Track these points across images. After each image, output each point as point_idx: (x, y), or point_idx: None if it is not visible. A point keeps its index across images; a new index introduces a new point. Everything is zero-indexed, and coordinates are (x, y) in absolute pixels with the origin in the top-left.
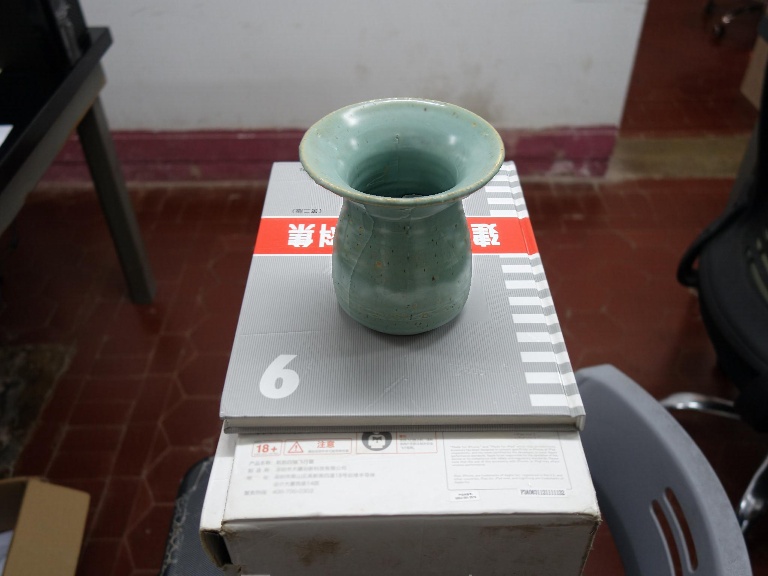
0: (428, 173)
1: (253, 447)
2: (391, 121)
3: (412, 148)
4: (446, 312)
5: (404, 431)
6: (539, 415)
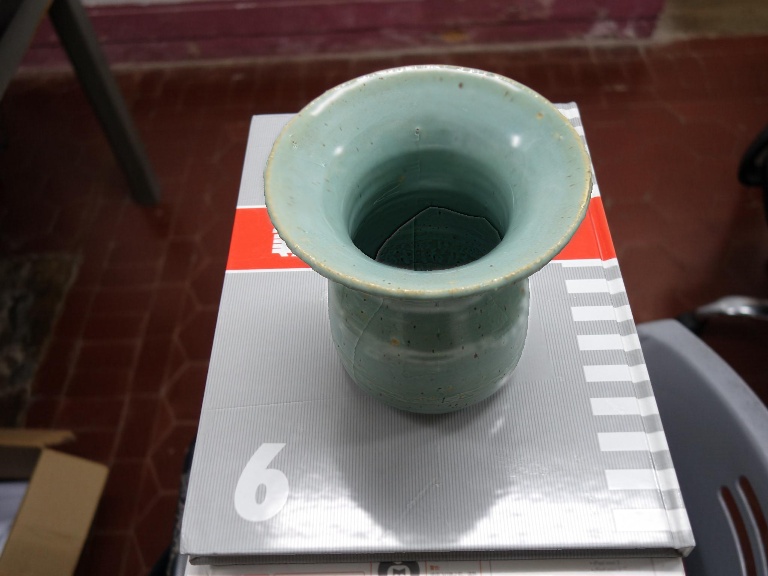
0: (465, 182)
1: None
2: (407, 106)
3: (441, 147)
4: (493, 386)
5: (436, 560)
6: (628, 547)
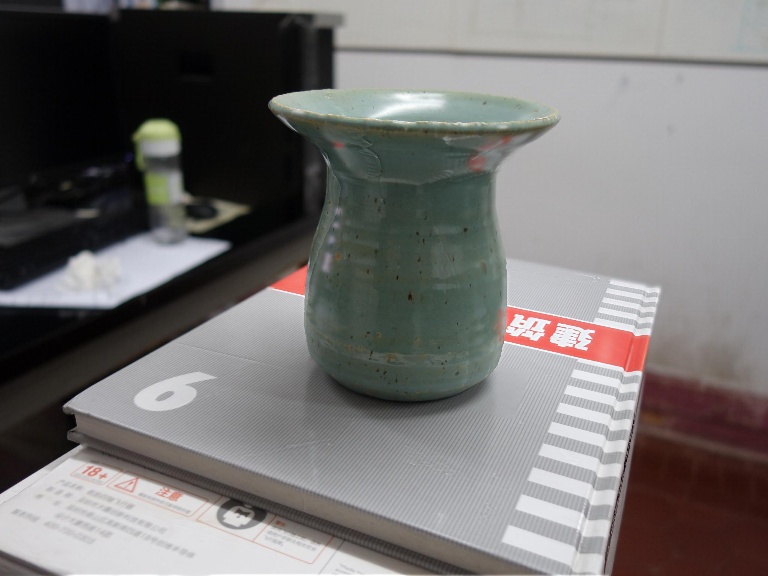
0: None
1: (83, 465)
2: (436, 111)
3: None
4: (430, 368)
5: (287, 517)
6: (506, 559)
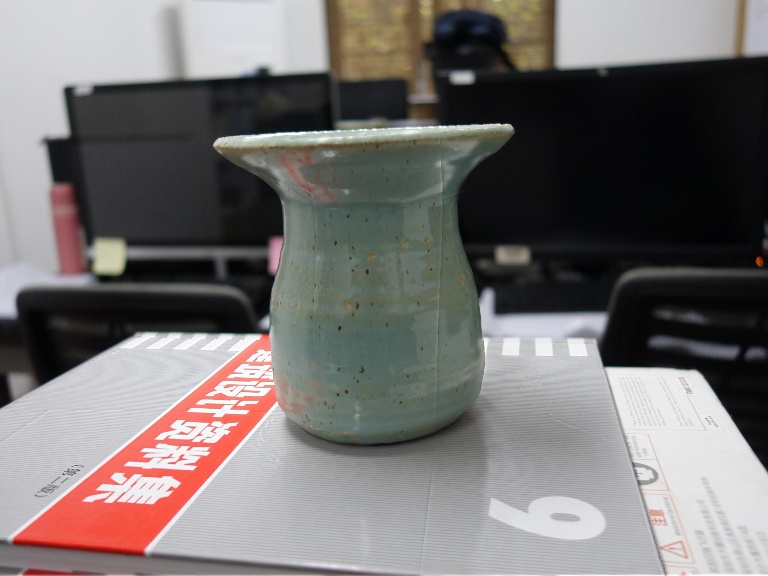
0: None
1: None
2: None
3: None
4: None
5: None
6: None
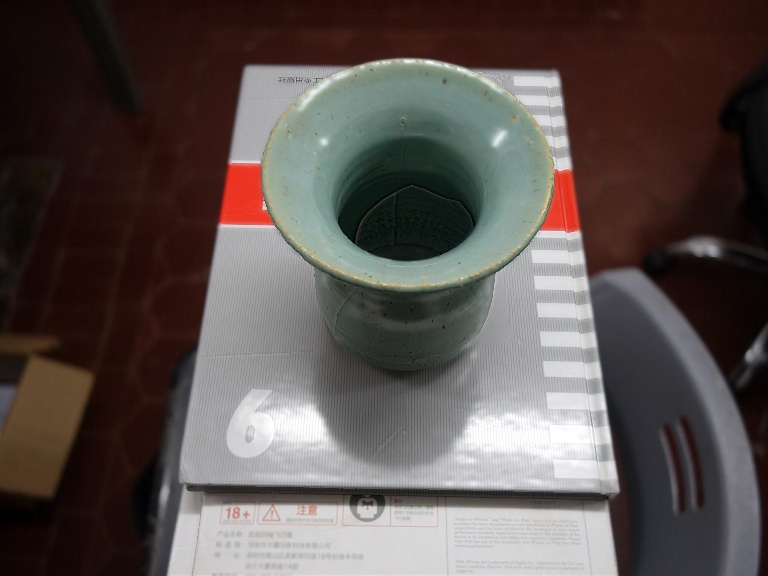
0: (444, 169)
1: (222, 510)
2: (395, 98)
3: (423, 137)
4: (458, 349)
5: (400, 495)
6: (563, 491)
